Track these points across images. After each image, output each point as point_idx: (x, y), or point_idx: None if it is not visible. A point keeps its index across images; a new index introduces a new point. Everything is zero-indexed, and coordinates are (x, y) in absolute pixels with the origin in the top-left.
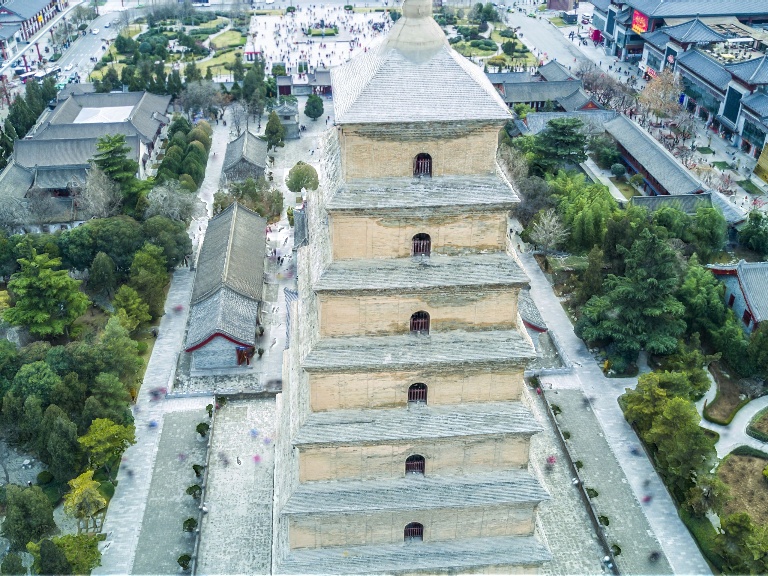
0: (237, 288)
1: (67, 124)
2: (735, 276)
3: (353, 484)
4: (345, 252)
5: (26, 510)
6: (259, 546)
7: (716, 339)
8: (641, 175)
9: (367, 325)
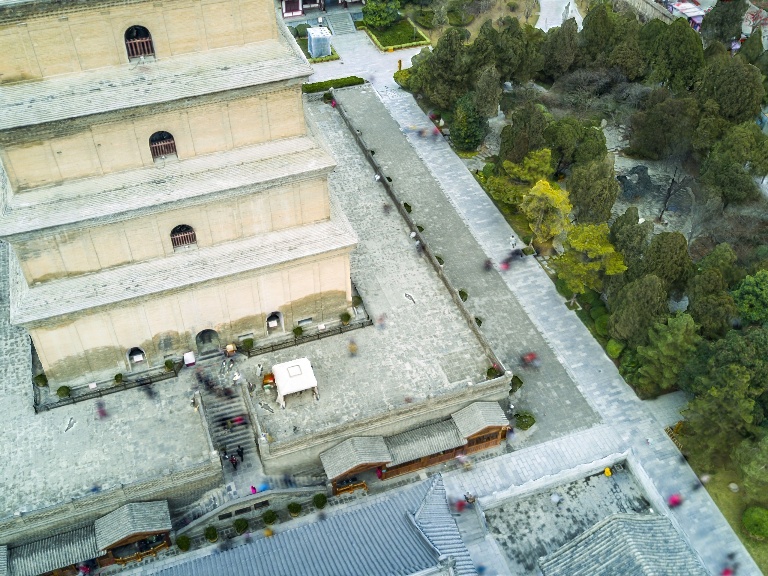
0: None
1: None
2: None
3: None
4: None
5: None
6: None
7: None
8: None
9: None
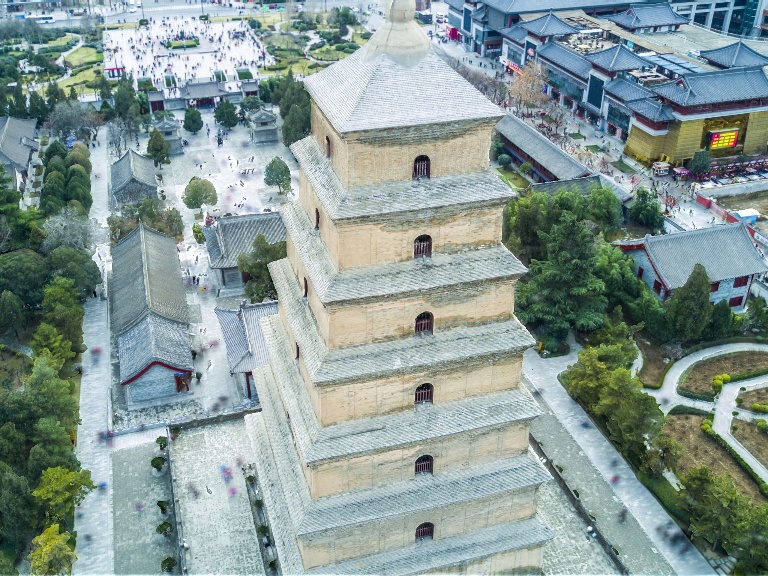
0: (164, 313)
1: None
2: (642, 250)
3: (365, 494)
4: (350, 261)
5: None
6: (252, 574)
7: (634, 310)
8: (529, 164)
9: (374, 332)
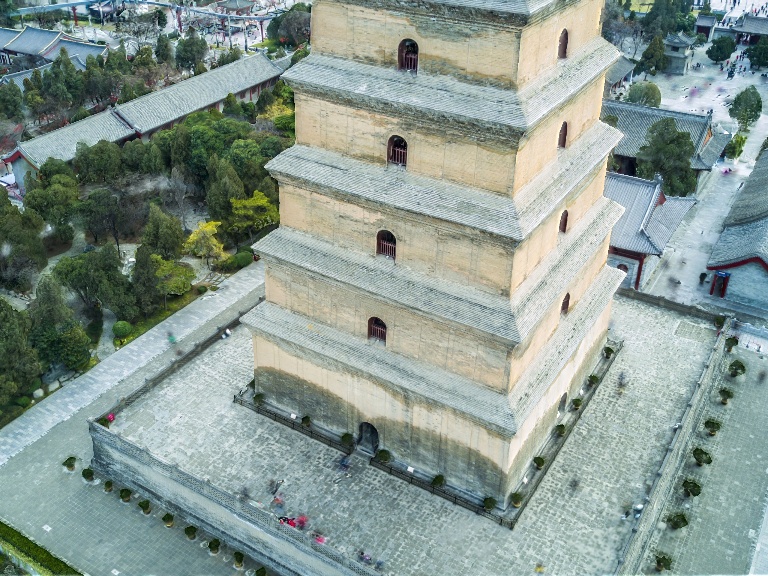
0: None
1: None
2: None
3: (325, 245)
4: None
5: (158, 231)
6: None
7: None
8: None
9: (355, 46)
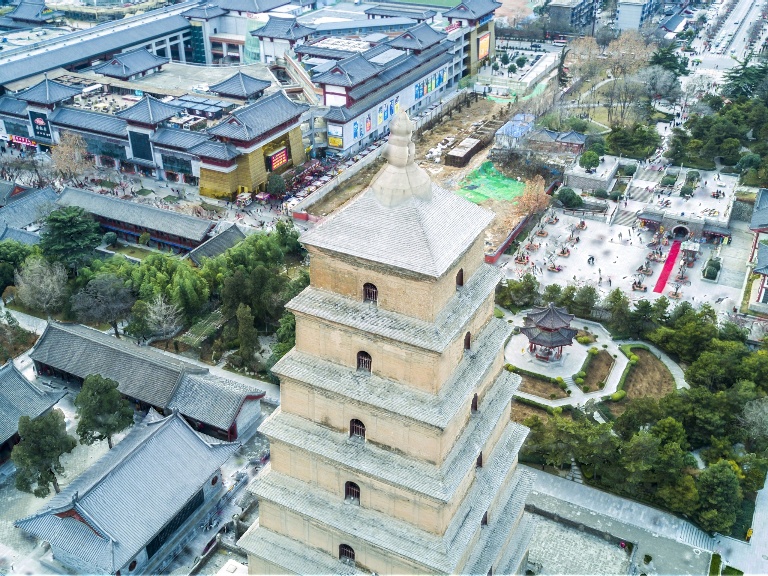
0: None
1: None
2: None
3: (465, 573)
4: (440, 382)
5: None
6: None
7: None
8: (147, 234)
9: None
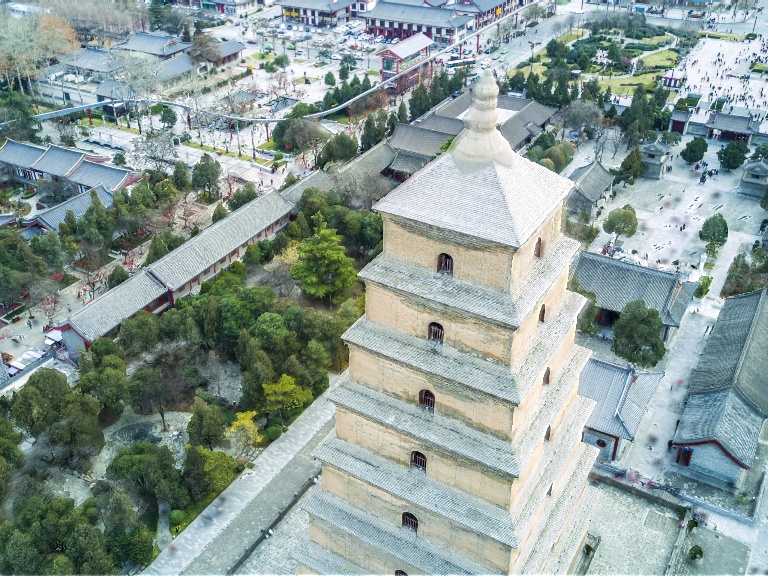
0: None
1: (448, 117)
2: None
3: (359, 512)
4: (375, 316)
5: (202, 420)
6: None
7: None
8: None
9: (384, 384)
